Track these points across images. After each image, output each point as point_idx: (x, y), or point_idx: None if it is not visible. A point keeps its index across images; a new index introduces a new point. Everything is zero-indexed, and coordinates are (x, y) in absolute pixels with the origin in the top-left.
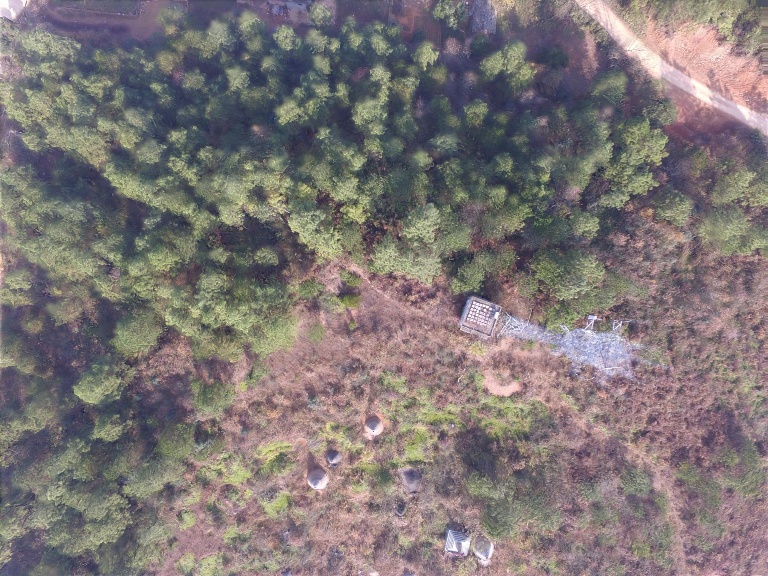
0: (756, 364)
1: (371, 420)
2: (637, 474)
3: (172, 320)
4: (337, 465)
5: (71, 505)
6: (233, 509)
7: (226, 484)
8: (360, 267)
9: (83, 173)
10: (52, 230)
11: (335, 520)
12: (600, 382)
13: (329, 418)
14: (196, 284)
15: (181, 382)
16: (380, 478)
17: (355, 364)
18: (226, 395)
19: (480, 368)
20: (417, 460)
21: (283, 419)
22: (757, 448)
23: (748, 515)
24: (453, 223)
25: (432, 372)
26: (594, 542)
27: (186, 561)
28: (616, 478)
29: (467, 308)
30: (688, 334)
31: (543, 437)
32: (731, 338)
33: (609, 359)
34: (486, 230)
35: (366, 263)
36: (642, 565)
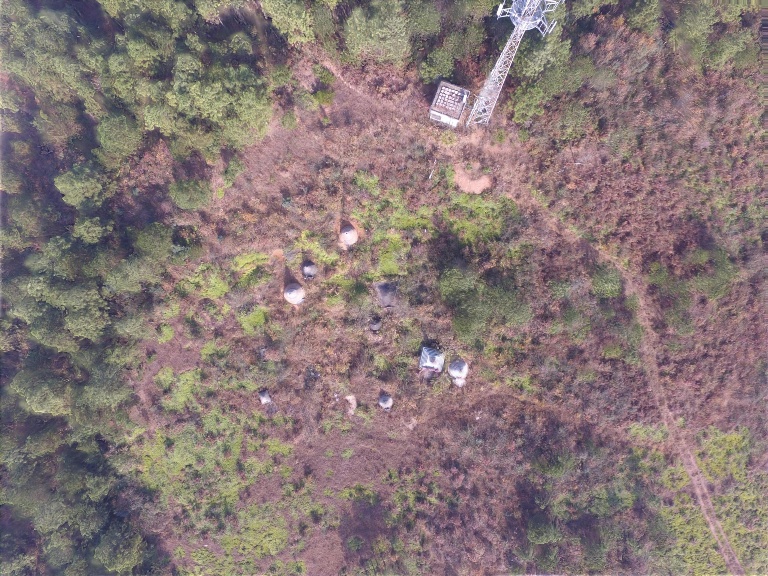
0: (730, 181)
1: (345, 227)
2: (608, 279)
3: (149, 112)
4: (313, 277)
5: (51, 301)
6: (211, 322)
7: (204, 298)
8: (333, 64)
9: (69, 1)
10: (36, 36)
11: (311, 336)
12: (569, 176)
13: (304, 225)
14: (172, 69)
15: (160, 191)
16: (355, 291)
17: (328, 161)
18: (202, 193)
19: (451, 163)
20: (392, 274)
21: (259, 225)
22: (731, 263)
23: (722, 328)
24: (423, 14)
25: (404, 168)
26: (567, 355)
27: (165, 374)
28: (587, 282)
29: (436, 93)
30: (659, 137)
31: (513, 234)
32: (703, 148)
33: (579, 155)
34: (455, 19)
35: (339, 58)
36: (615, 376)
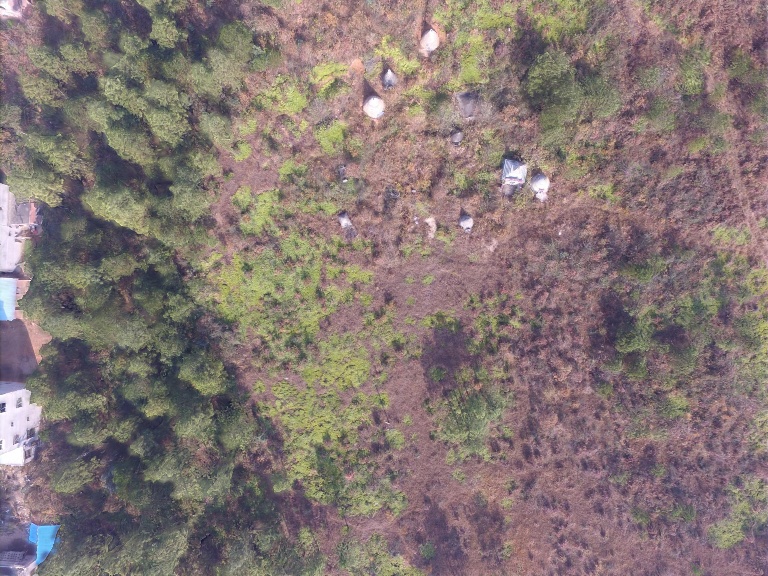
0: None
1: (427, 30)
2: (692, 73)
3: None
4: None
5: (130, 103)
6: (289, 137)
7: (281, 114)
8: None
9: None
10: None
11: (391, 152)
12: None
13: (386, 28)
14: None
15: None
16: (436, 102)
17: None
18: None
19: None
20: (472, 83)
21: (340, 29)
22: None
23: None
24: None
25: None
26: (650, 158)
27: (242, 194)
28: (672, 76)
29: None
30: None
31: (601, 23)
32: None
33: None
34: None
35: None
36: (699, 176)
